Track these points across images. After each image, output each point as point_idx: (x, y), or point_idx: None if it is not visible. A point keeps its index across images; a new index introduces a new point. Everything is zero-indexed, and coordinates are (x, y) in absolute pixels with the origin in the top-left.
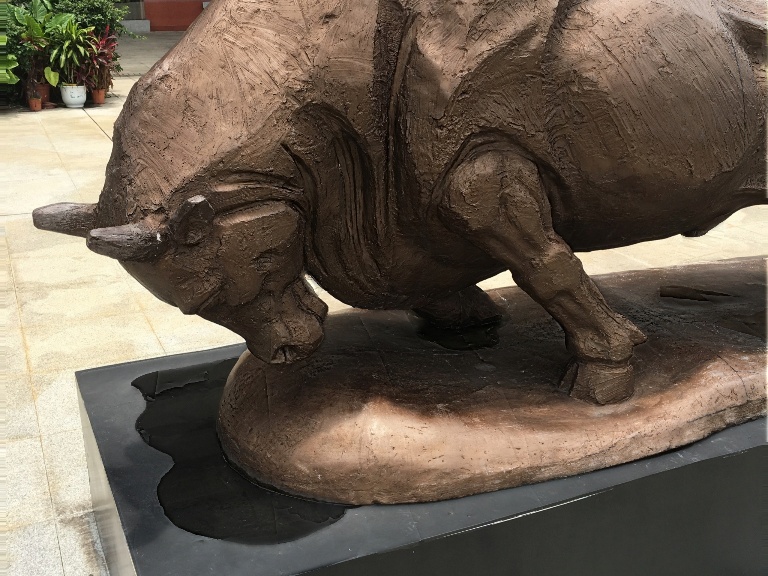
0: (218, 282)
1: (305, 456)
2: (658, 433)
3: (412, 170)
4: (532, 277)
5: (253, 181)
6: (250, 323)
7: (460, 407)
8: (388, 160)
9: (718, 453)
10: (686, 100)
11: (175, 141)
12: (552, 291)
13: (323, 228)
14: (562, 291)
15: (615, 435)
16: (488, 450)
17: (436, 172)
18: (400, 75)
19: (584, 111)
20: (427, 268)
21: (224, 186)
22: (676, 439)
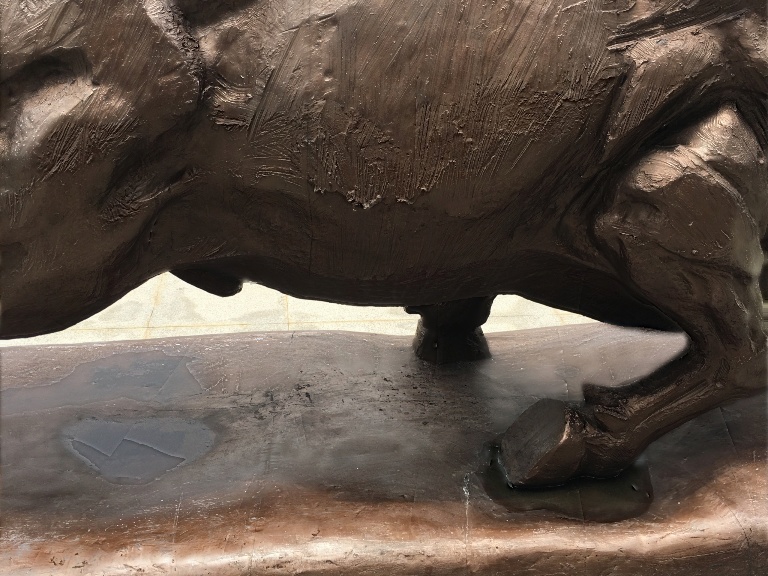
0: None
1: None
2: None
3: None
4: None
5: None
6: None
7: (616, 326)
8: None
9: None
10: None
11: None
12: None
13: None
14: None
15: None
16: None
17: None
18: None
19: None
20: None
21: None
22: None
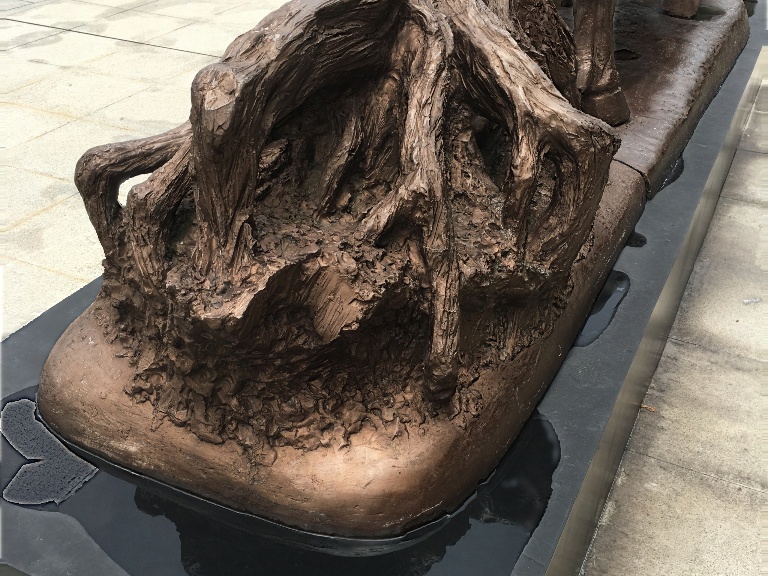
0: None
1: None
2: None
3: None
4: None
5: None
6: None
7: None
8: None
9: None
10: None
11: None
12: None
13: None
14: None
15: None
16: None
17: None
18: None
19: None
20: None
21: None
22: None
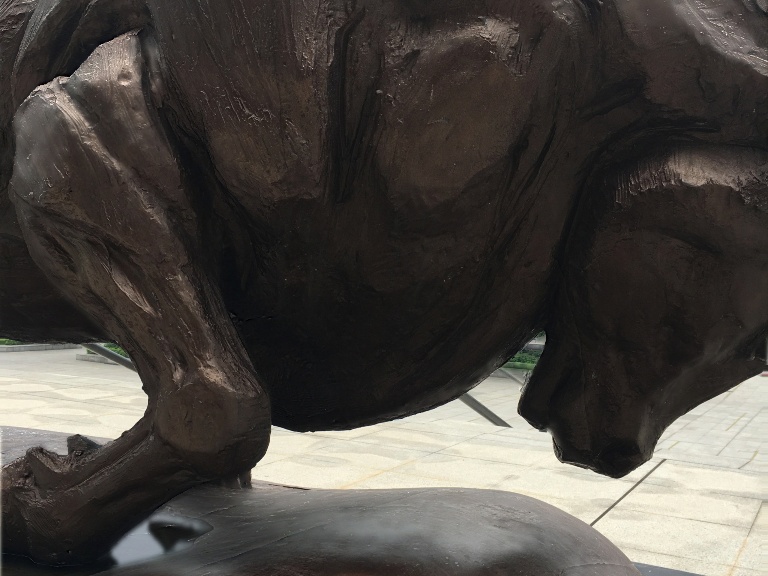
0: None
1: None
2: None
3: None
4: None
5: None
6: None
7: None
8: None
9: None
10: None
11: None
12: None
13: None
14: None
15: None
16: None
17: None
18: None
19: None
20: None
21: None
22: None
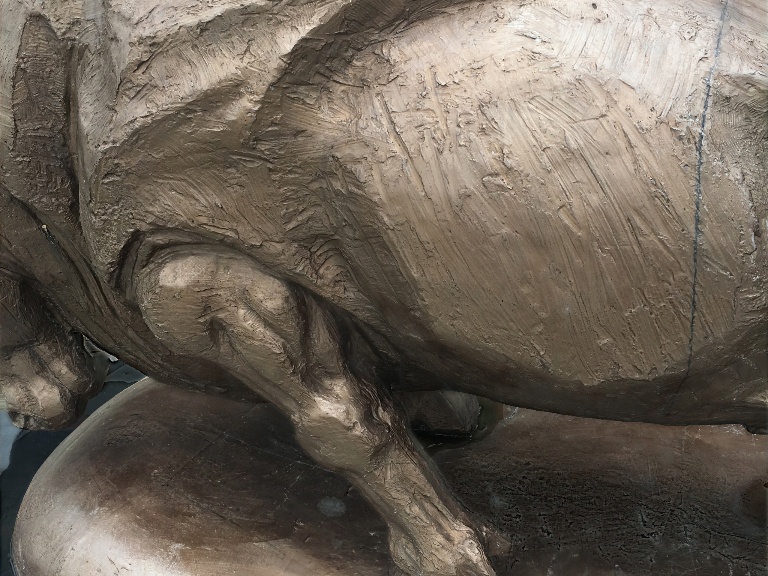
0: None
1: (24, 538)
2: None
3: None
4: (297, 435)
5: None
6: None
7: (200, 558)
8: None
9: None
10: (538, 240)
11: None
12: (327, 463)
13: (58, 292)
14: (343, 468)
15: None
16: None
17: (103, 270)
18: None
19: (354, 222)
20: None
21: None
22: None
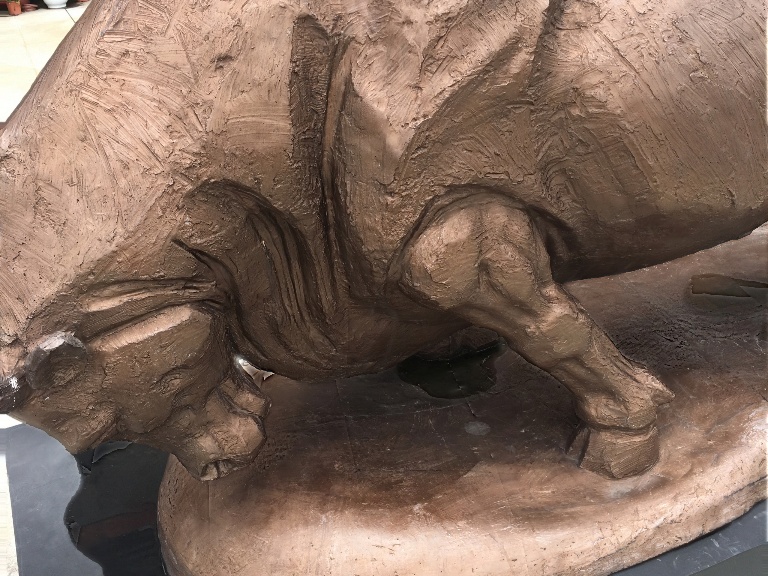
0: (110, 416)
1: None
2: (688, 517)
3: (358, 245)
4: (527, 346)
5: (140, 289)
6: (167, 441)
7: (442, 506)
8: (328, 228)
9: (762, 538)
10: (727, 111)
11: (27, 247)
12: (553, 359)
13: (252, 314)
14: (566, 358)
15: (635, 526)
16: (476, 567)
17: (389, 249)
18: (333, 123)
19: (589, 139)
20: (396, 332)
21: (100, 302)
22: (710, 521)
